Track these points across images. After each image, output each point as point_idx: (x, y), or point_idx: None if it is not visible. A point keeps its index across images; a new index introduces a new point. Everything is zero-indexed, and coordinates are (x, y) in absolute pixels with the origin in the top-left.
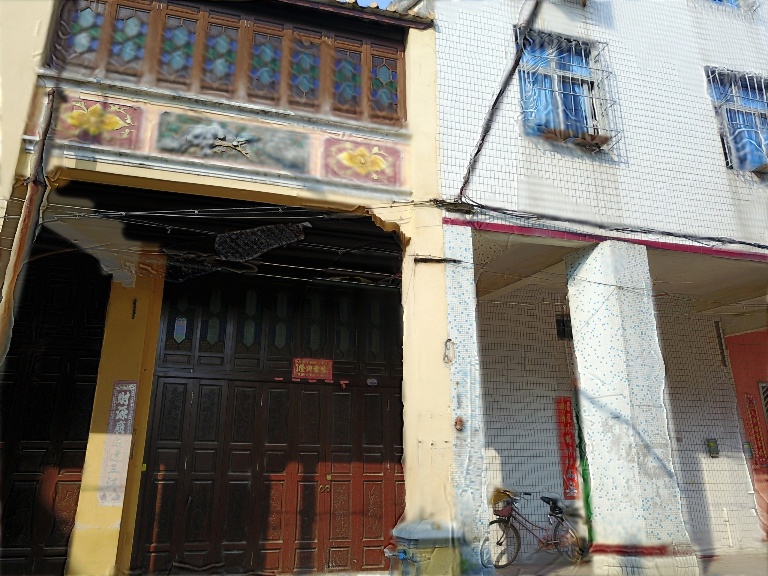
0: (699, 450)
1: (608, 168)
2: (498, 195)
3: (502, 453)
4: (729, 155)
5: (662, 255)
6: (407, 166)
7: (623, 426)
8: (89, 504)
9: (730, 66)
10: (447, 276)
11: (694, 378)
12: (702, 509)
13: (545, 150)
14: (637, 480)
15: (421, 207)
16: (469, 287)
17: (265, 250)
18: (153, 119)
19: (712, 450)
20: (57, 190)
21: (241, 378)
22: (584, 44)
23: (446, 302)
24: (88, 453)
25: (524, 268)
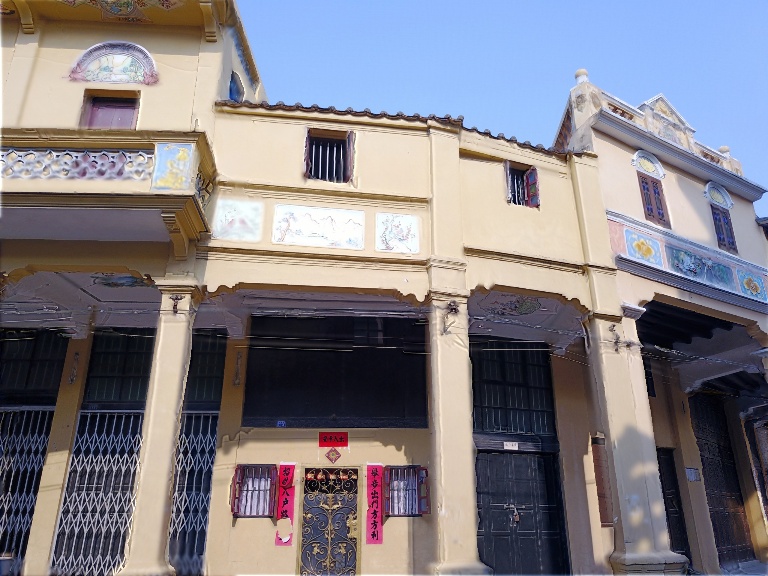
0: None
1: None
2: None
3: None
4: None
5: None
6: None
7: None
8: (767, 523)
9: None
10: None
11: None
12: None
13: None
14: None
15: None
16: None
17: None
18: None
19: None
20: None
21: (759, 466)
22: None
23: None
24: None
25: None
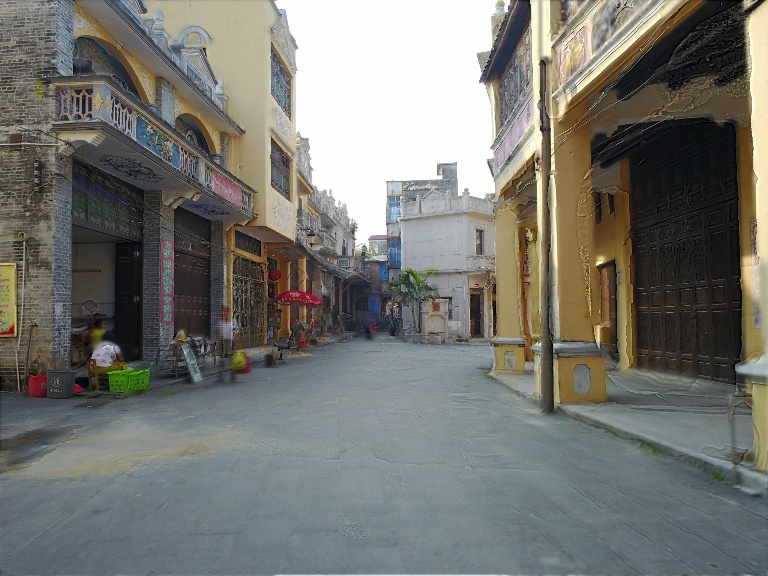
0: None
1: None
2: None
3: None
4: None
5: None
6: None
7: None
8: (746, 327)
9: None
10: None
11: None
12: None
13: None
14: None
15: None
16: None
17: None
18: (591, 26)
19: None
20: (559, 124)
21: None
22: None
23: None
24: (742, 284)
25: None
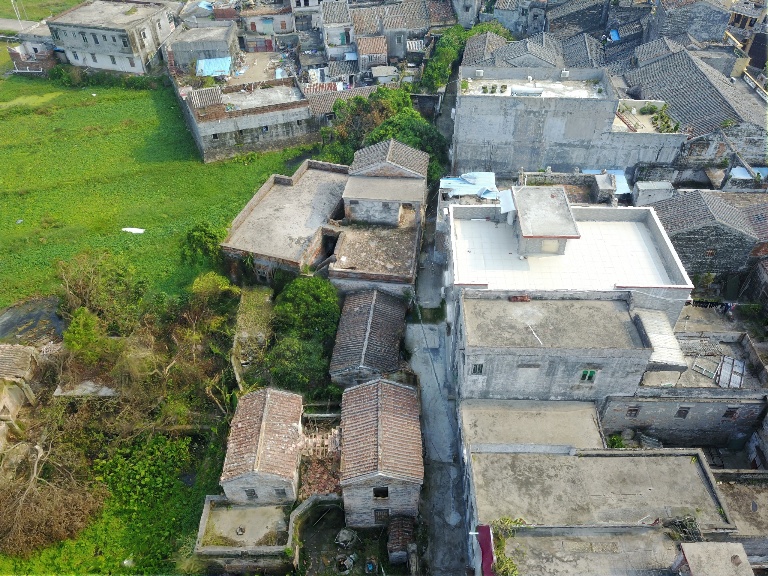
0: None
1: None
2: None
3: None
4: None
5: None
6: None
7: None
8: None
9: None
10: None
11: None
12: None
13: None
14: None
15: None
16: None
17: (571, 8)
18: None
19: None
20: None
21: None
22: None
23: None
24: None
25: None
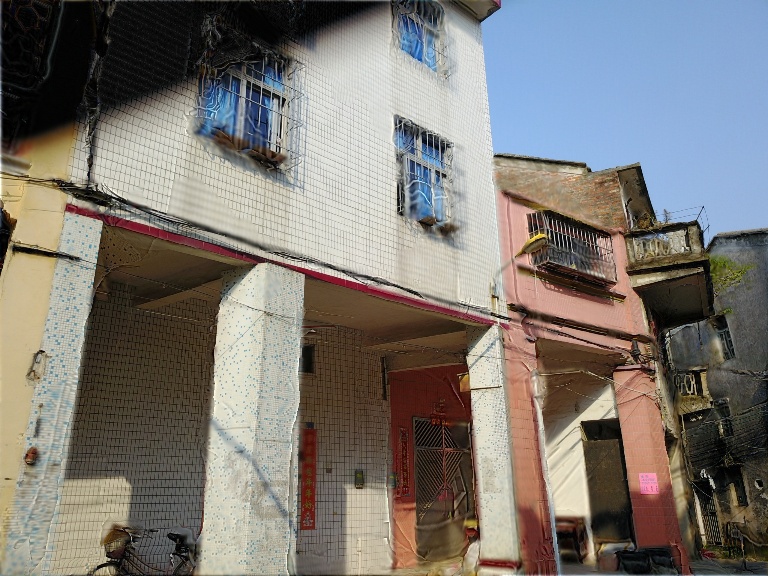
0: (346, 481)
1: (282, 189)
2: (146, 191)
3: (135, 483)
4: (402, 202)
5: (319, 286)
6: (29, 133)
7: (244, 462)
8: None
9: (417, 121)
10: (56, 274)
11: (353, 410)
12: (339, 540)
13: (214, 155)
14: (246, 521)
15: (38, 185)
16: (84, 291)
17: None
18: None
19: (358, 481)
20: None
21: None
22: (282, 58)
23: (48, 305)
24: None
25: (185, 279)
